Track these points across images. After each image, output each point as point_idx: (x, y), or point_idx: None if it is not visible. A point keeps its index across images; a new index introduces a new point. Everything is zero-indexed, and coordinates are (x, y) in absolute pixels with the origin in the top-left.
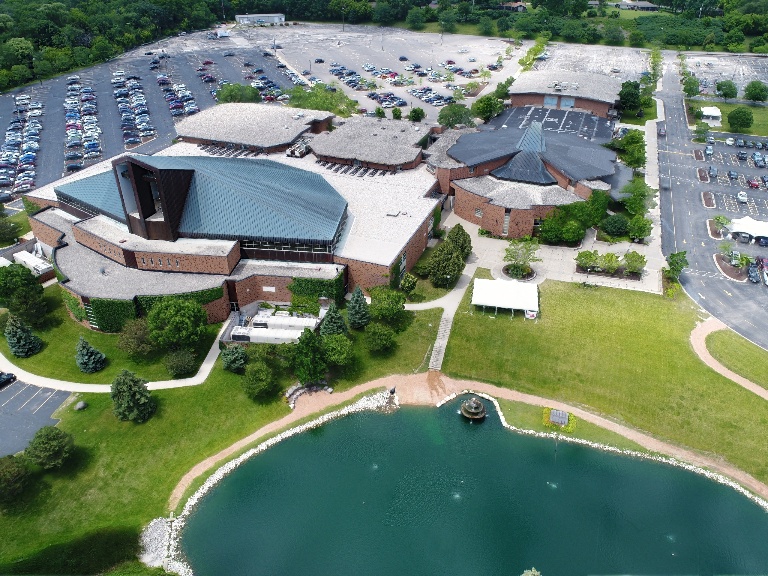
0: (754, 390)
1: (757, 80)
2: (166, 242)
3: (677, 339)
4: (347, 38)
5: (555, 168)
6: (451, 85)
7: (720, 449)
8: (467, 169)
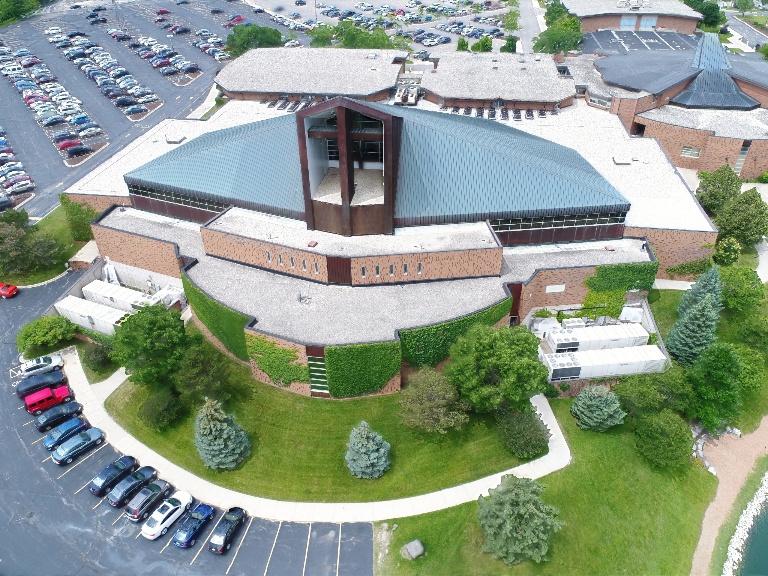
0: None
1: None
2: (382, 237)
3: None
4: None
5: (760, 86)
6: (480, 17)
7: None
8: (651, 98)
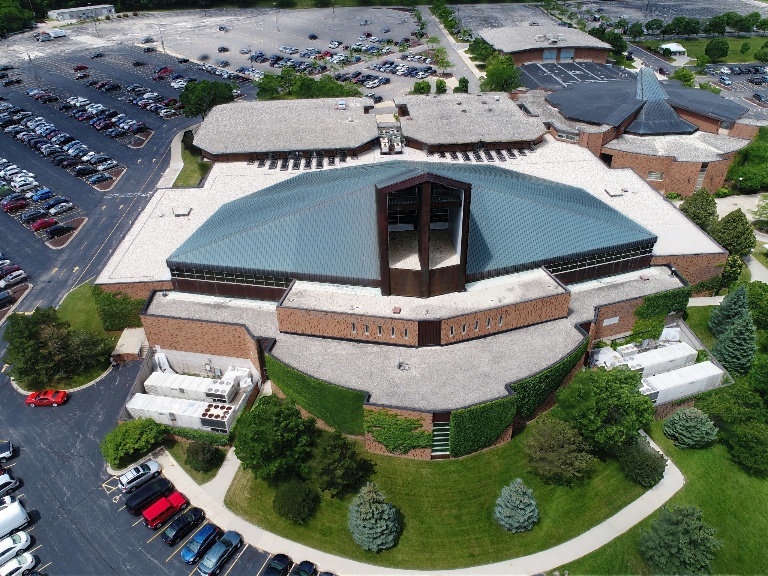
0: None
1: None
2: (457, 295)
3: None
4: (221, 23)
5: (698, 113)
6: (408, 56)
7: None
8: (612, 130)
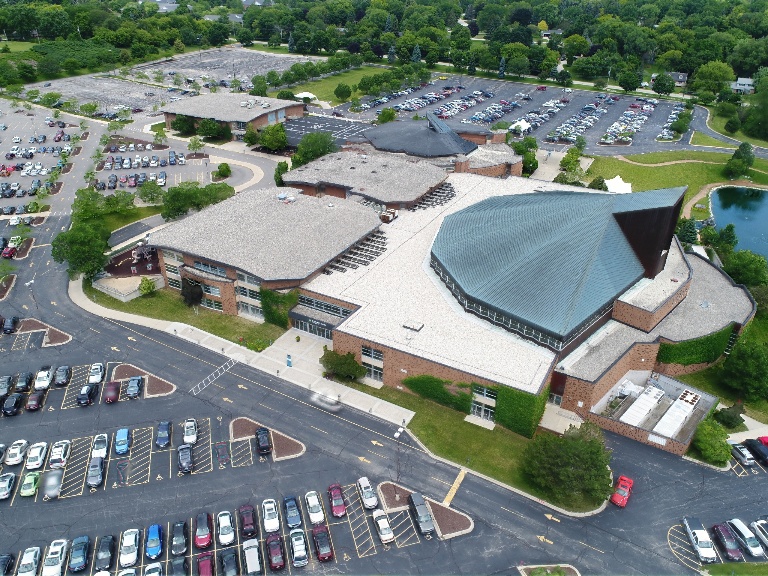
0: (665, 164)
1: (256, 72)
2: None
3: None
4: None
5: (474, 133)
6: None
7: (698, 184)
8: None
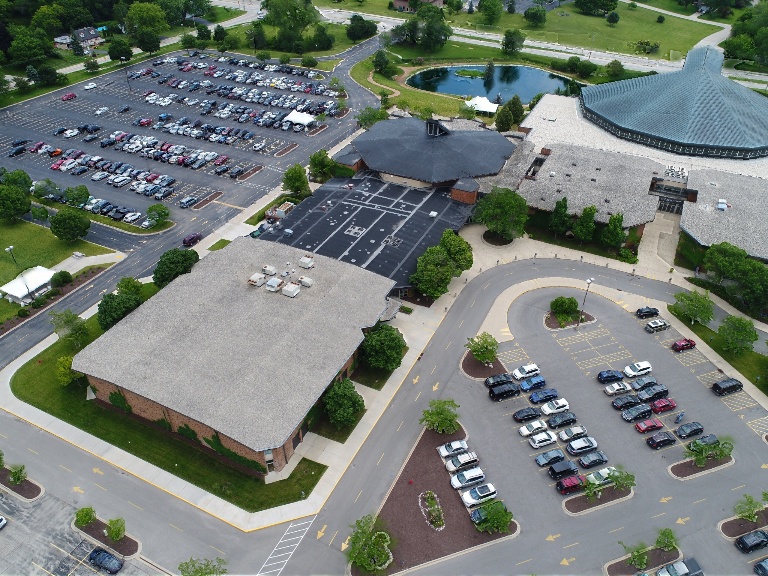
0: (388, 87)
1: None
2: None
3: (405, 95)
4: None
5: None
6: None
7: None
8: None
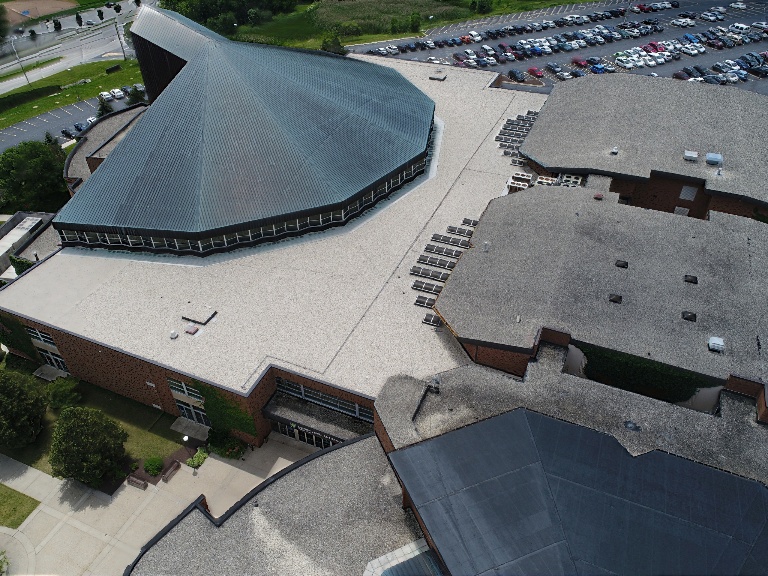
0: None
1: None
2: None
3: None
4: None
5: None
6: None
7: None
8: None
